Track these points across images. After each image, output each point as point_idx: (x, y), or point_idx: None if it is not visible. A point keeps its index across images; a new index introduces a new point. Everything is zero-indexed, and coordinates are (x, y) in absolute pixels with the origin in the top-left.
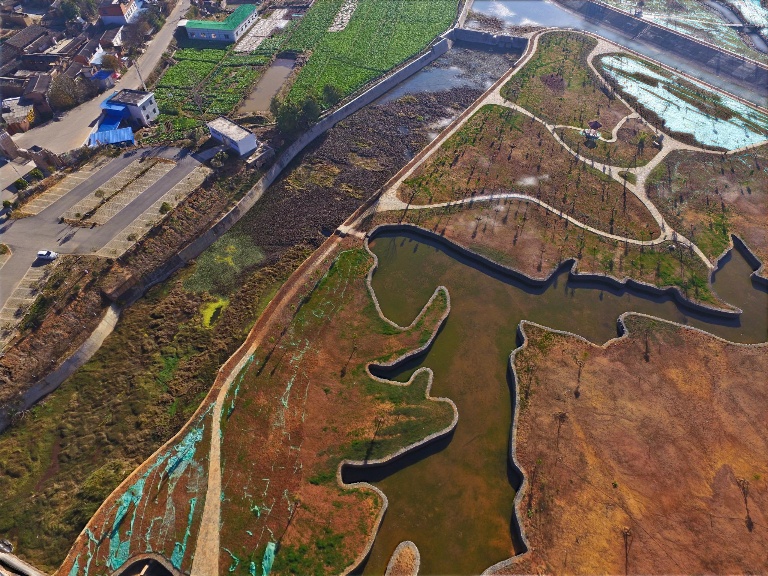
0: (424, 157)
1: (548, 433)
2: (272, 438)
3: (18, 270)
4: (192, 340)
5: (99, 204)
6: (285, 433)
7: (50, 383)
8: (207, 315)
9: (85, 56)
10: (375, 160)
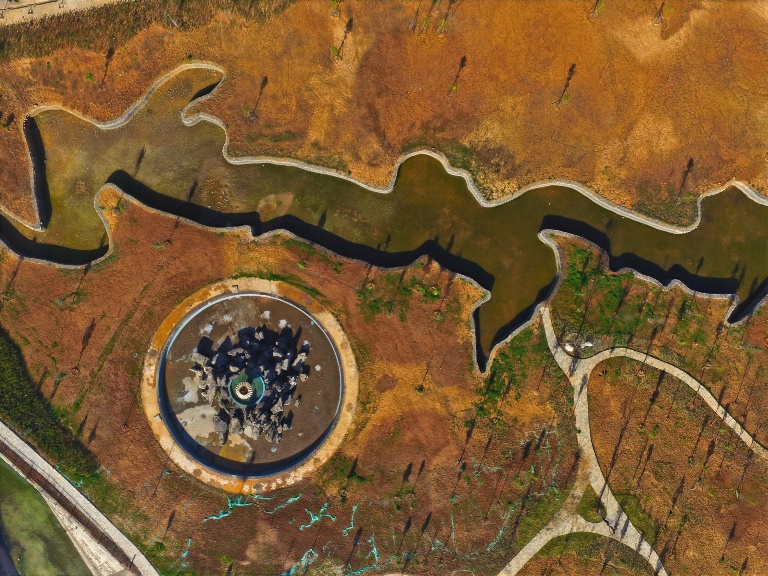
0: None
1: None
2: None
3: None
4: None
5: None
6: None
7: None
8: None
9: None
10: None
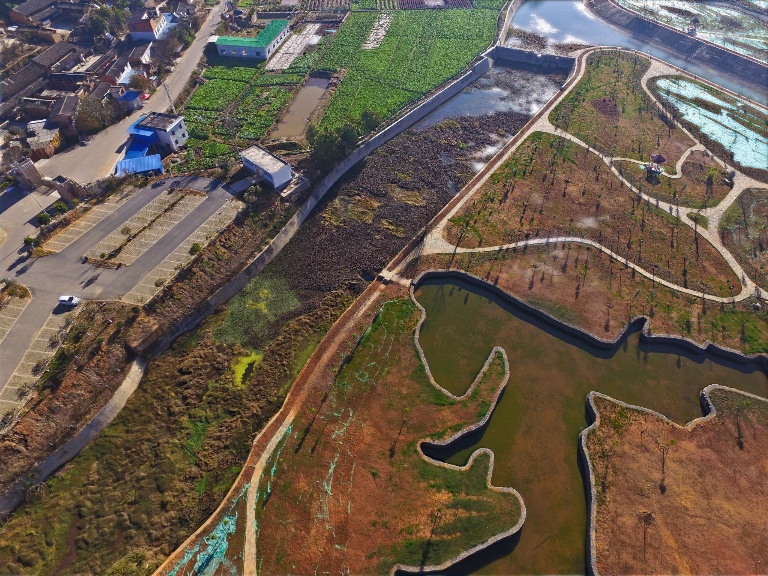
0: (471, 191)
1: (632, 539)
2: (314, 534)
3: (38, 317)
4: (223, 402)
5: (125, 241)
6: (329, 528)
7: (69, 451)
8: (239, 372)
9: (113, 76)
10: (416, 193)
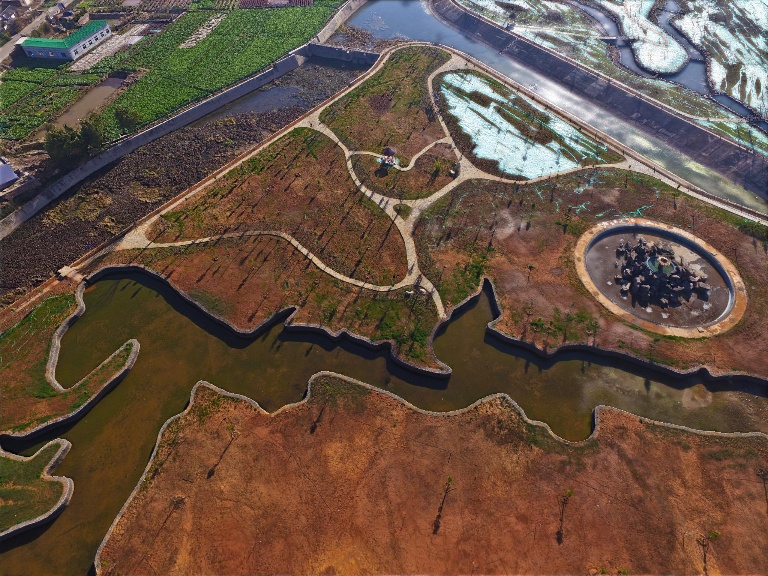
0: (199, 187)
1: (152, 523)
2: None
3: None
4: None
5: None
6: None
7: None
8: None
9: None
10: (156, 190)
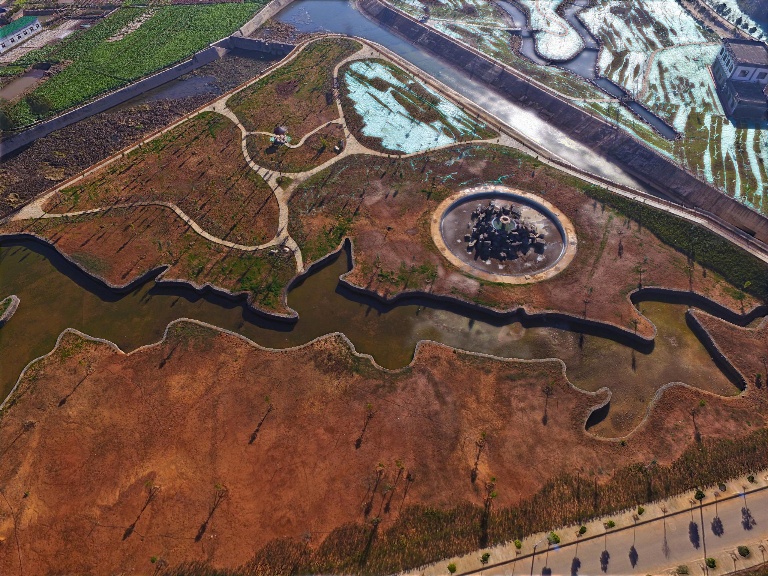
0: (100, 165)
1: (2, 443)
2: None
3: None
4: None
5: None
6: None
7: None
8: None
9: None
10: (62, 169)
